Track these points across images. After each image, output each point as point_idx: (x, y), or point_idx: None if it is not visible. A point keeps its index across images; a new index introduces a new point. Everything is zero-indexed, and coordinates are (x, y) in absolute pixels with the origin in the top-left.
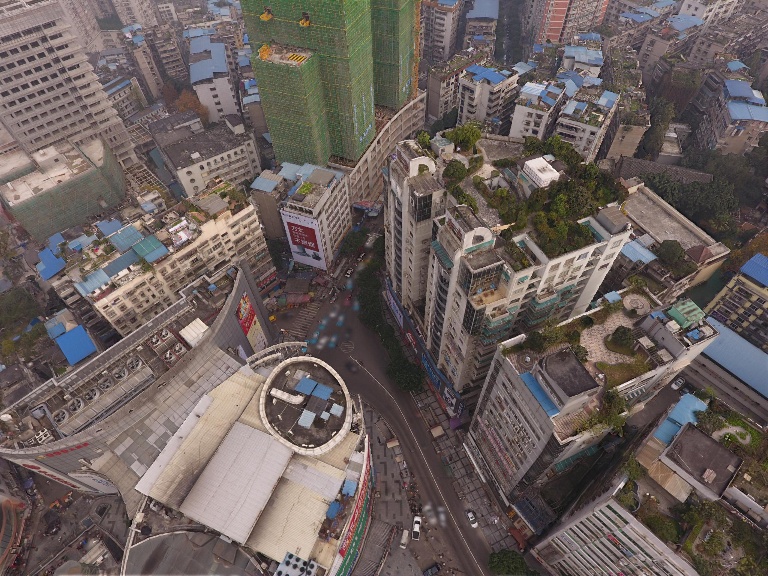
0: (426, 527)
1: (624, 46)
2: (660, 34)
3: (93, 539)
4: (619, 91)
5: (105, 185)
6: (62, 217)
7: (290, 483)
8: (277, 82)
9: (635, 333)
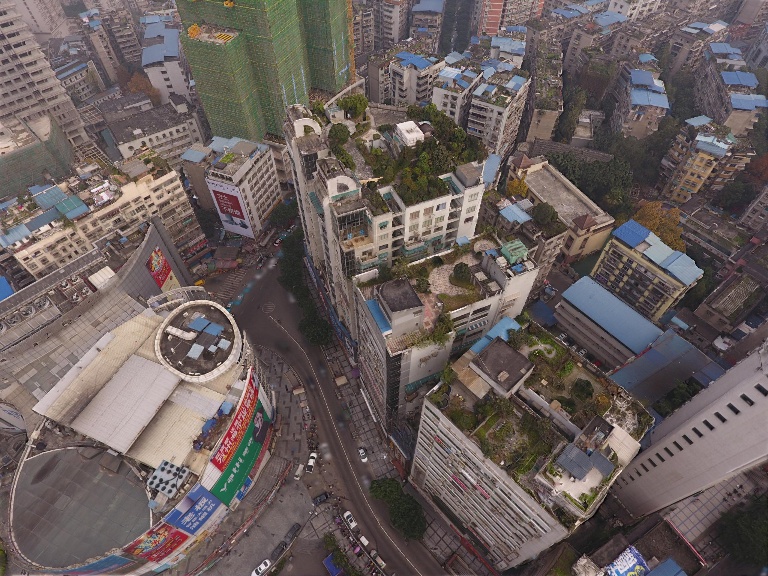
0: (321, 462)
1: (551, 39)
2: (585, 29)
3: (10, 473)
4: (529, 76)
5: (50, 159)
6: (6, 188)
7: (174, 405)
8: (206, 59)
9: (473, 269)
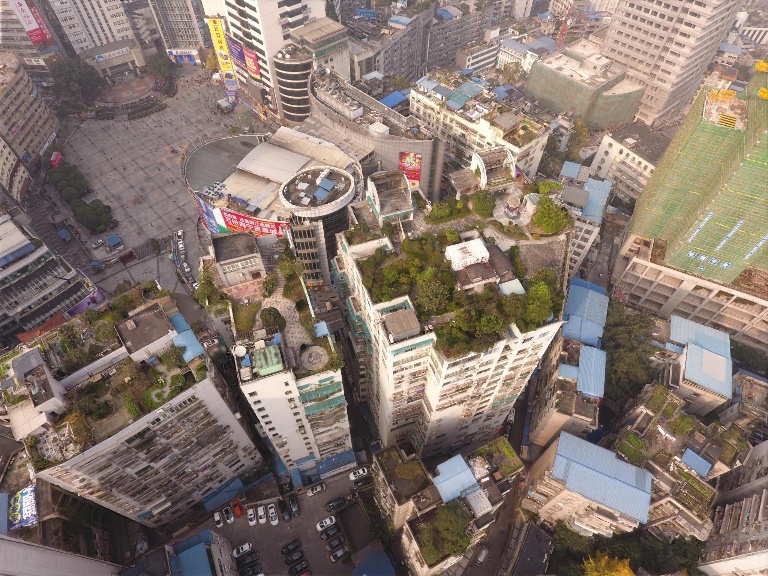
0: None
1: None
2: None
3: None
4: None
5: (585, 105)
6: (547, 96)
7: (266, 185)
8: None
9: (272, 329)
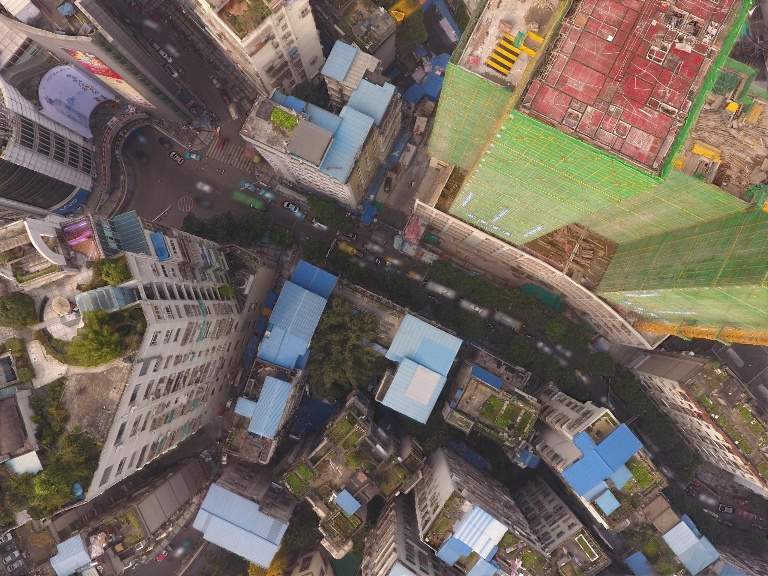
0: None
1: None
2: None
3: None
4: None
5: None
6: None
7: None
8: None
9: None
